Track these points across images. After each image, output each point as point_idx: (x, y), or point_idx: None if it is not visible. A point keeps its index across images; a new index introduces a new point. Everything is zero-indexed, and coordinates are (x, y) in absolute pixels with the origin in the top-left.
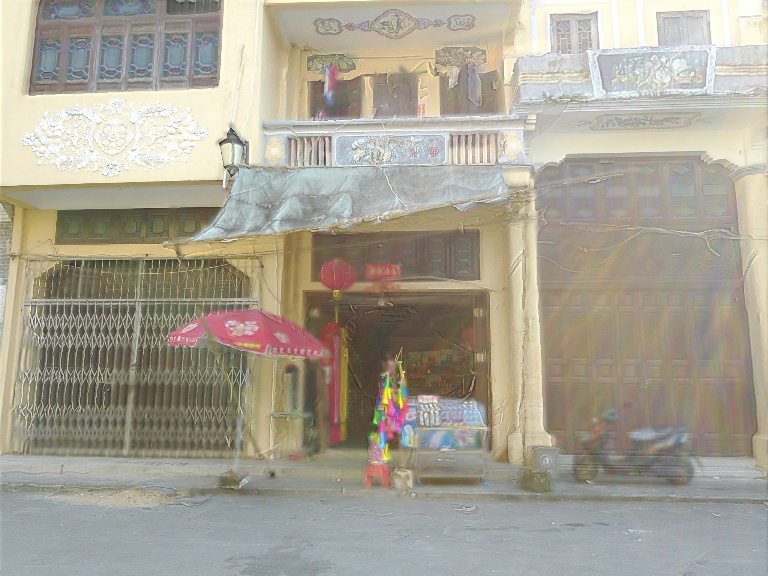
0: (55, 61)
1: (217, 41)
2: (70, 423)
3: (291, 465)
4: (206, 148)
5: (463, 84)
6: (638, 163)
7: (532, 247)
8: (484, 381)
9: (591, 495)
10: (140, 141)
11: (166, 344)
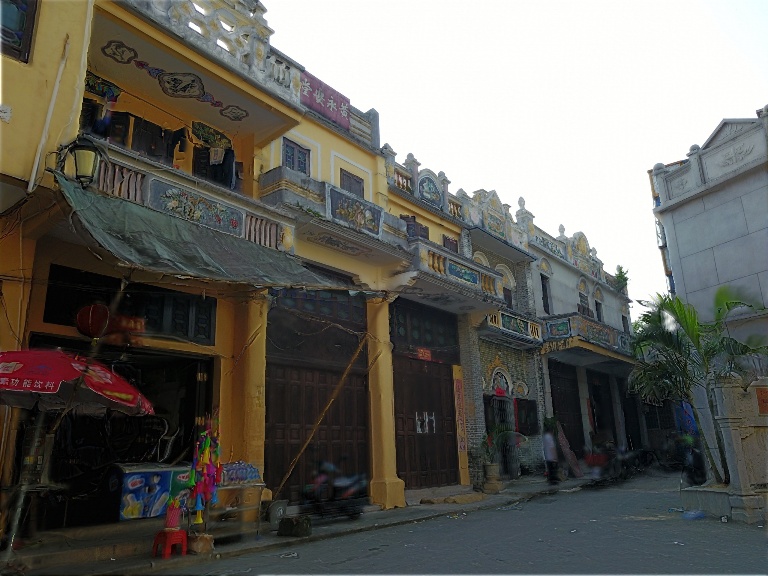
0: None
1: (24, 8)
2: None
3: (50, 551)
4: (8, 133)
5: (229, 166)
6: (322, 272)
7: (265, 324)
8: None
9: (337, 532)
10: None
11: None
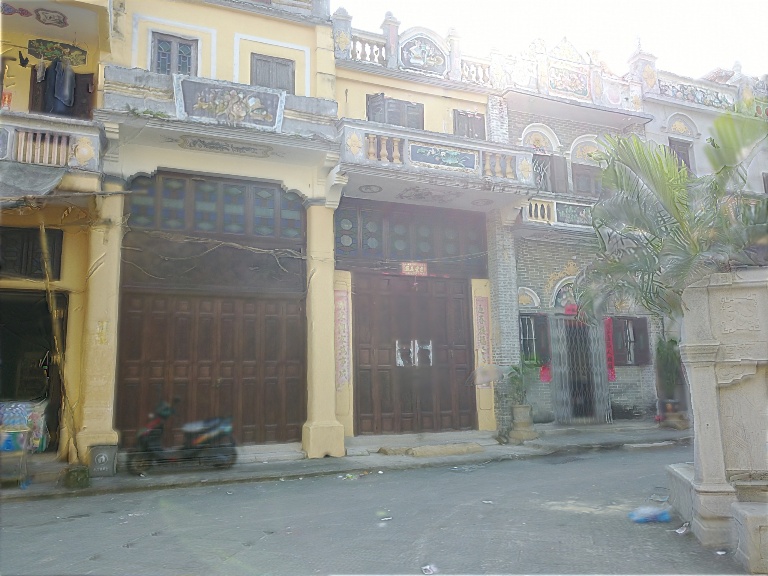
0: None
1: None
2: None
3: None
4: None
5: (49, 81)
6: (227, 184)
7: (113, 252)
8: (57, 384)
9: (128, 488)
10: None
11: None
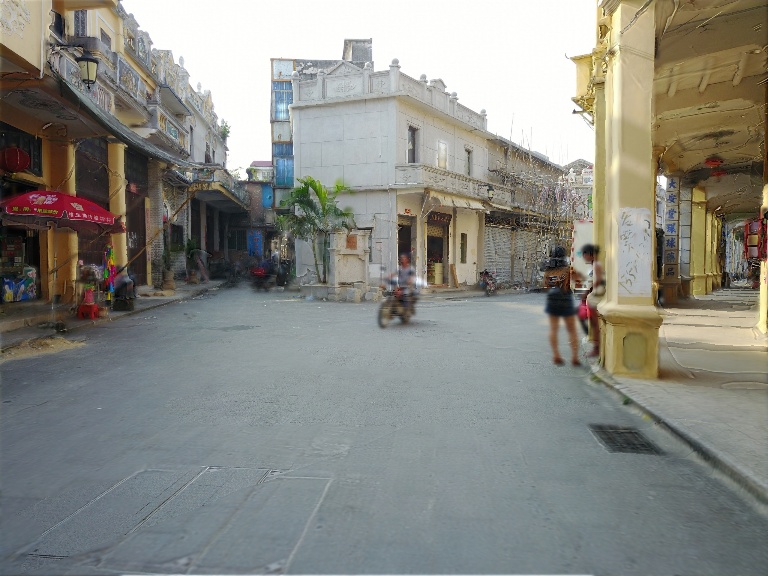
0: None
1: None
2: None
3: (33, 316)
4: None
5: (60, 30)
6: None
7: None
8: (38, 251)
9: None
10: None
11: None
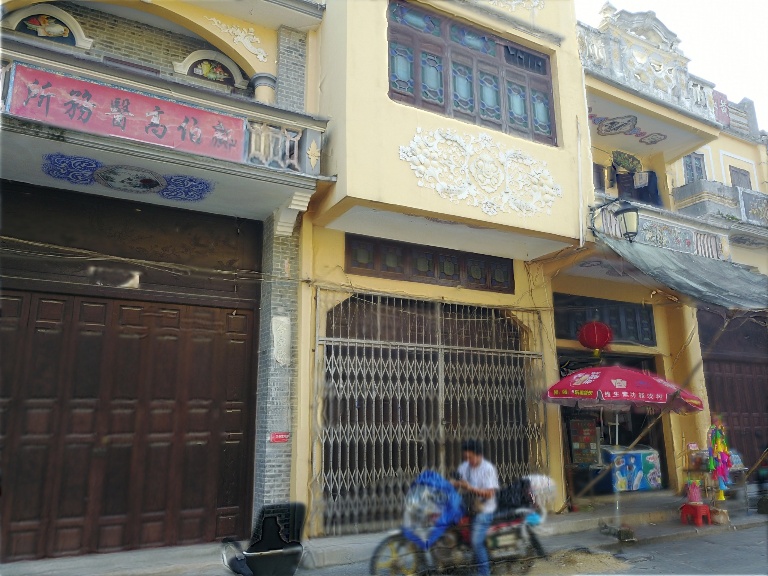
0: (407, 71)
1: (547, 103)
2: (384, 491)
3: (615, 515)
4: (563, 205)
5: (655, 187)
6: None
7: (697, 324)
8: (661, 431)
9: None
10: (510, 184)
11: (471, 396)
